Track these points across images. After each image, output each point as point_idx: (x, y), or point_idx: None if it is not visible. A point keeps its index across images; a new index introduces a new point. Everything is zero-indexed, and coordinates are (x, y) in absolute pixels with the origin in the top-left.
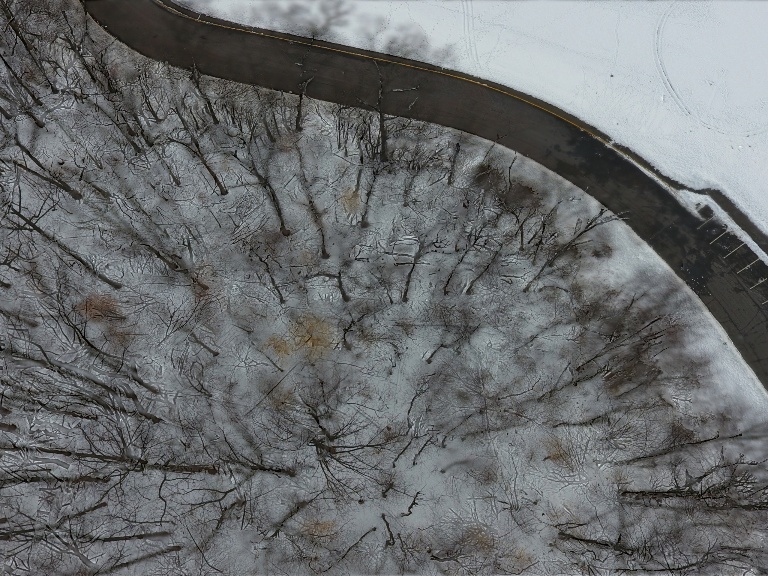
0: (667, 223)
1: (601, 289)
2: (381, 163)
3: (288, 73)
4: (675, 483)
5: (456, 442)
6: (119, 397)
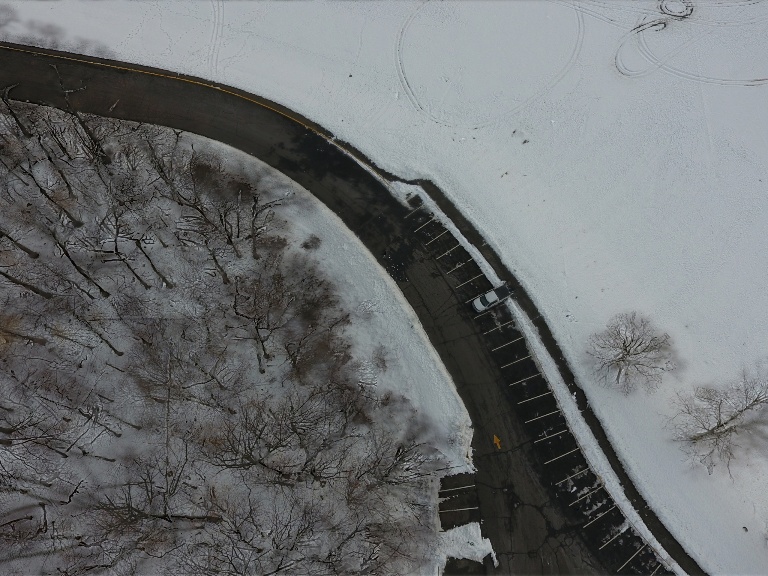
0: (376, 213)
1: None
2: (103, 165)
3: (28, 83)
4: None
5: (131, 431)
6: None
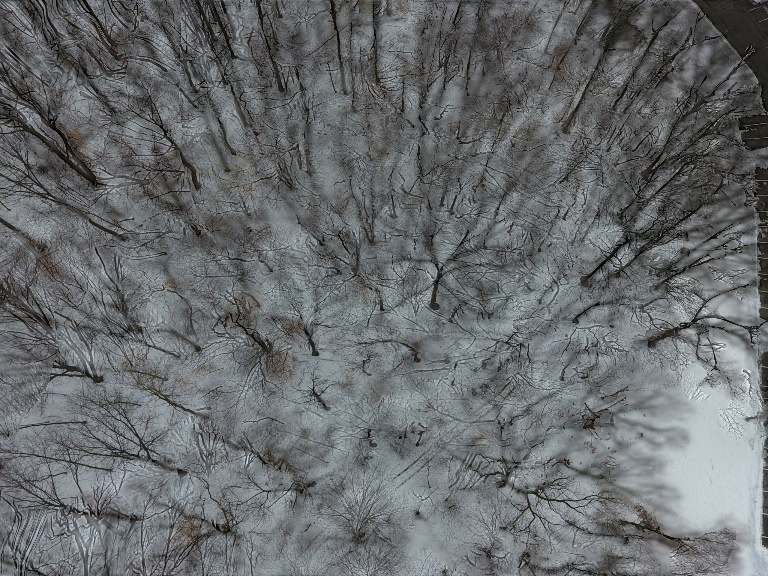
0: None
1: None
2: None
3: None
4: None
5: (478, 75)
6: (208, 21)
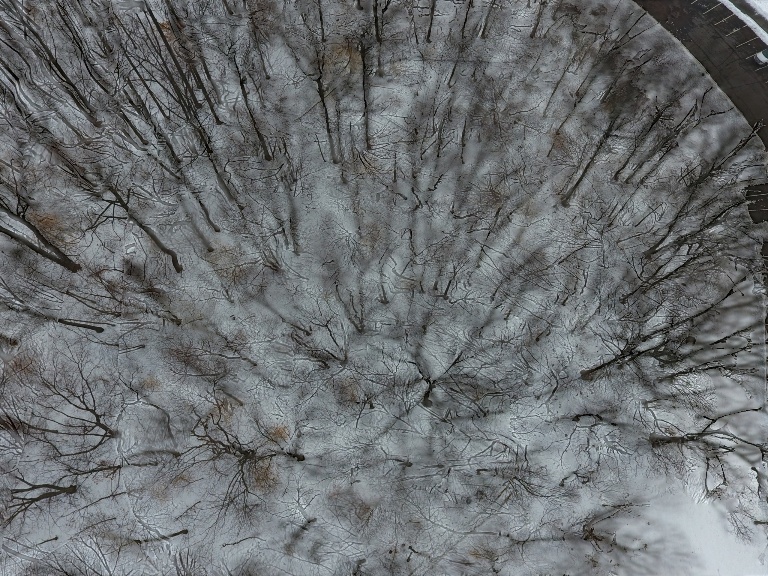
0: None
1: None
2: None
3: None
4: (656, 110)
5: (474, 142)
6: (191, 88)
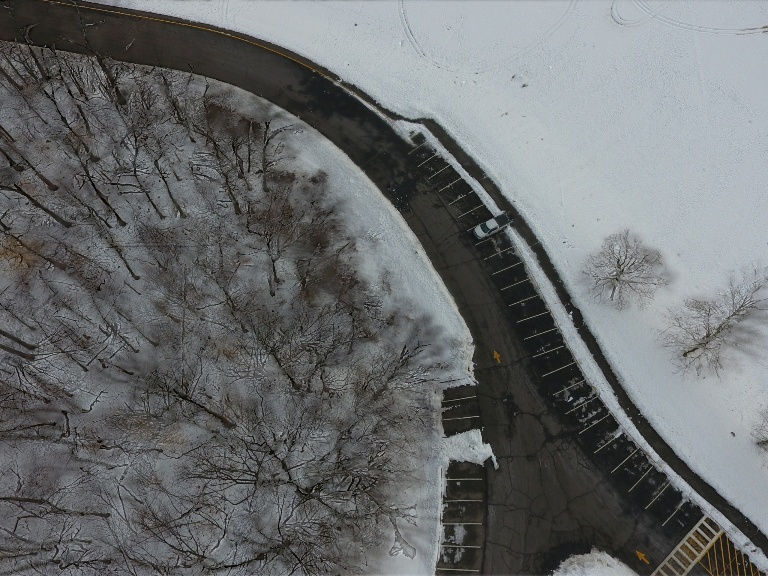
0: (381, 150)
1: (313, 210)
2: (119, 105)
3: (45, 30)
4: None
5: (148, 347)
6: None
